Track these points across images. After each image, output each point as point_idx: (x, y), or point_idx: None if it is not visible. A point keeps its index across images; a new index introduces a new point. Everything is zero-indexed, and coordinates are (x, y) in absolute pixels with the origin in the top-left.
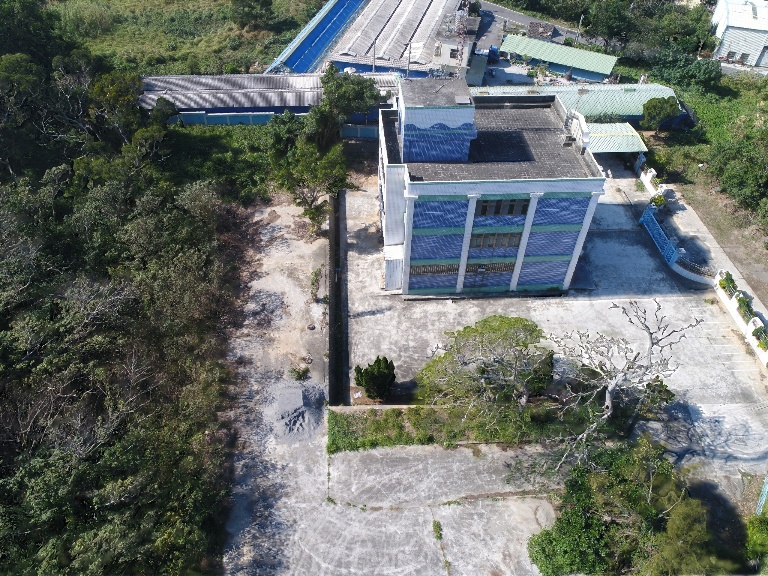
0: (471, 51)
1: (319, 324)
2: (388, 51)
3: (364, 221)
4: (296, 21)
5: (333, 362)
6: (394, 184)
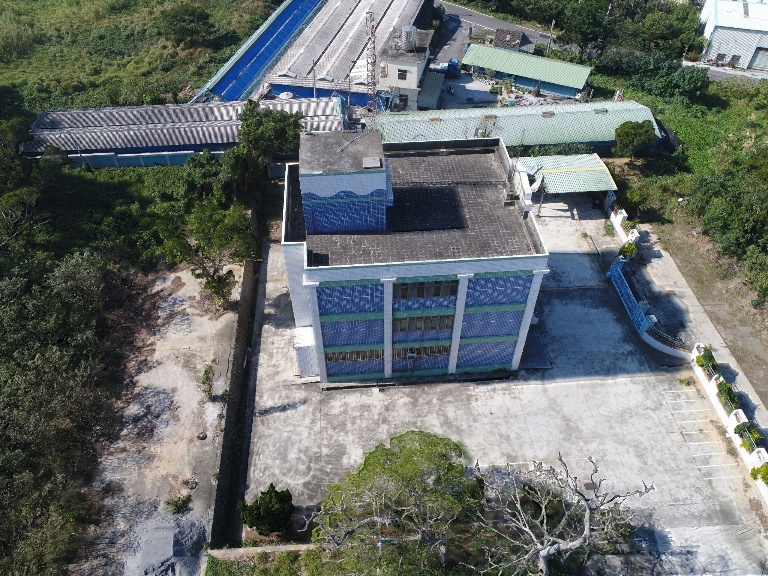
0: (424, 69)
1: (212, 431)
2: (332, 70)
3: (286, 284)
4: (238, 35)
5: (226, 481)
6: (295, 263)
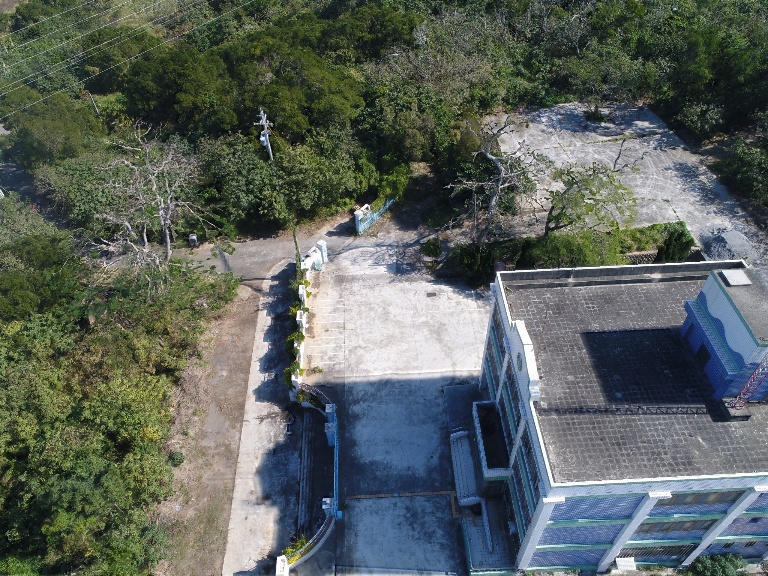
0: None
1: None
2: None
3: None
4: None
5: None
6: None
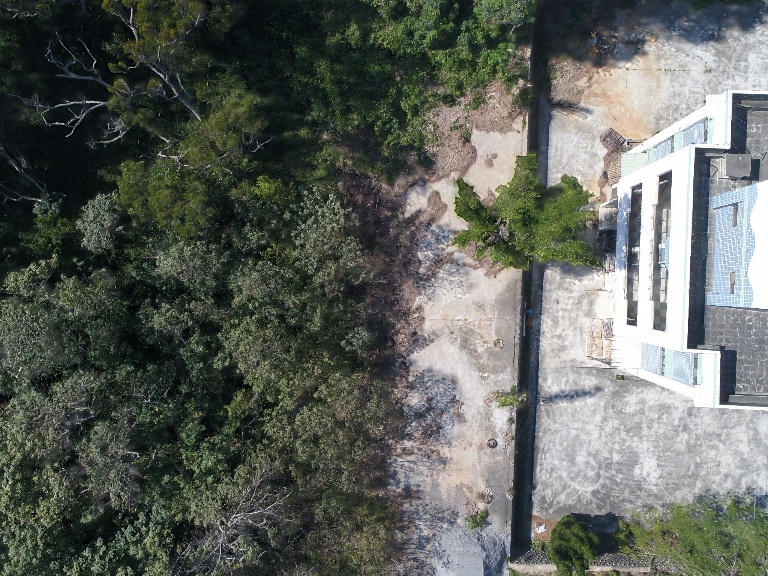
0: None
1: (502, 439)
2: None
3: None
4: None
5: None
6: None
